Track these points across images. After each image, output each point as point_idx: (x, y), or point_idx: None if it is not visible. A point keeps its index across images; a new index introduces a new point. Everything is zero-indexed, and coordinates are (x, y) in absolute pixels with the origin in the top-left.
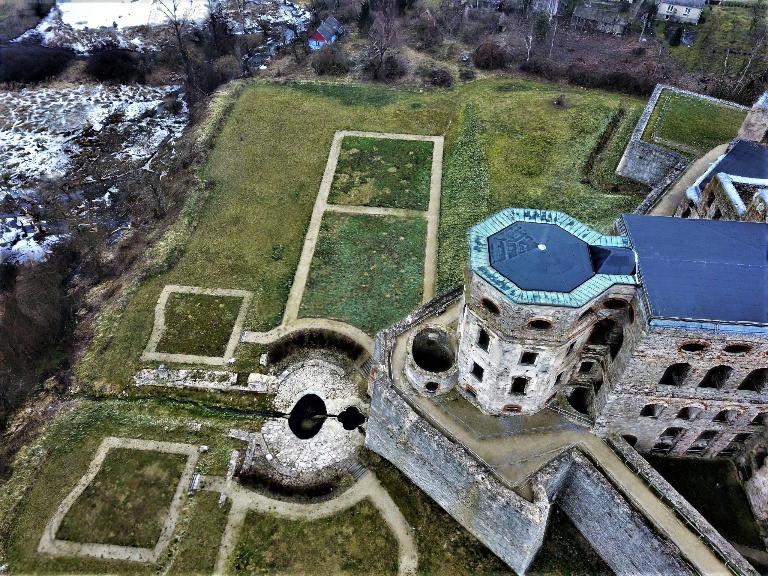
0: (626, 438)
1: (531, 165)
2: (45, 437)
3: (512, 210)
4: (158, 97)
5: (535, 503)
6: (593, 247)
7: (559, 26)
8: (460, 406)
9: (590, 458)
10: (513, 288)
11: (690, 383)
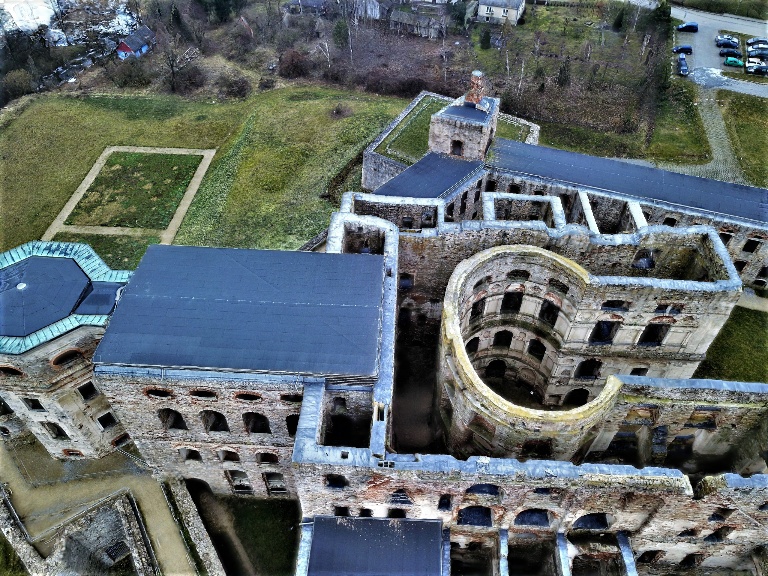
0: (188, 482)
1: (275, 179)
2: None
3: (34, 243)
4: None
5: (47, 560)
6: (89, 284)
7: (378, 31)
8: (33, 450)
9: (134, 506)
10: None
11: (195, 428)
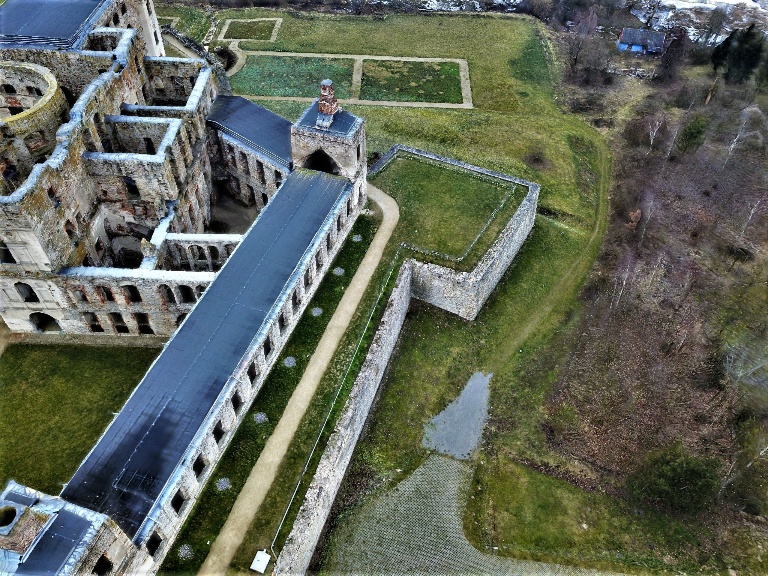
0: None
1: (399, 126)
2: (187, 7)
3: None
4: (509, 2)
5: None
6: None
7: None
8: None
9: None
10: None
11: None
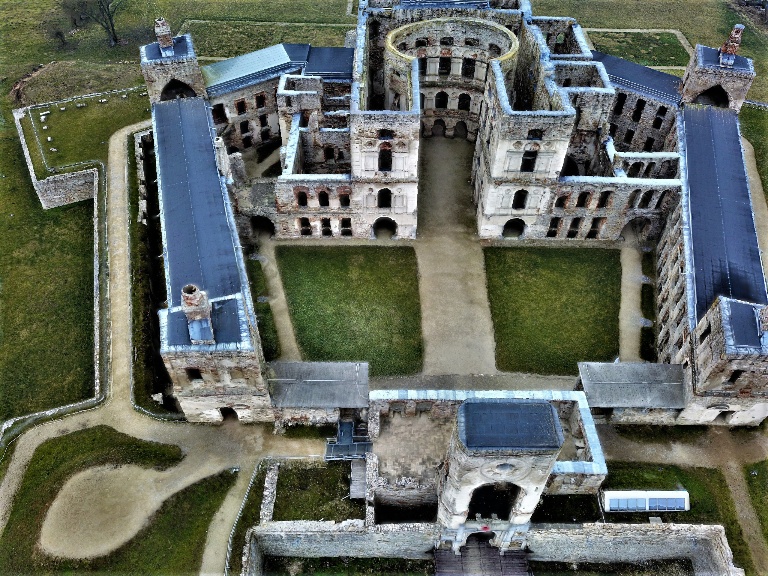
0: None
1: None
2: None
3: None
4: None
5: None
6: None
7: None
8: None
9: None
10: None
11: None
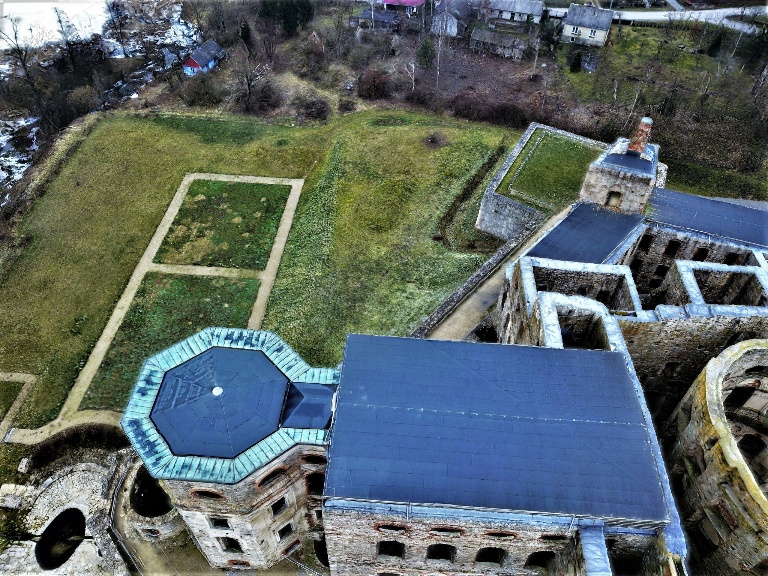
0: None
1: (381, 218)
2: None
3: (213, 330)
4: (9, 132)
5: None
6: (291, 386)
7: (457, 49)
8: (186, 554)
9: None
10: (162, 453)
11: (414, 557)
